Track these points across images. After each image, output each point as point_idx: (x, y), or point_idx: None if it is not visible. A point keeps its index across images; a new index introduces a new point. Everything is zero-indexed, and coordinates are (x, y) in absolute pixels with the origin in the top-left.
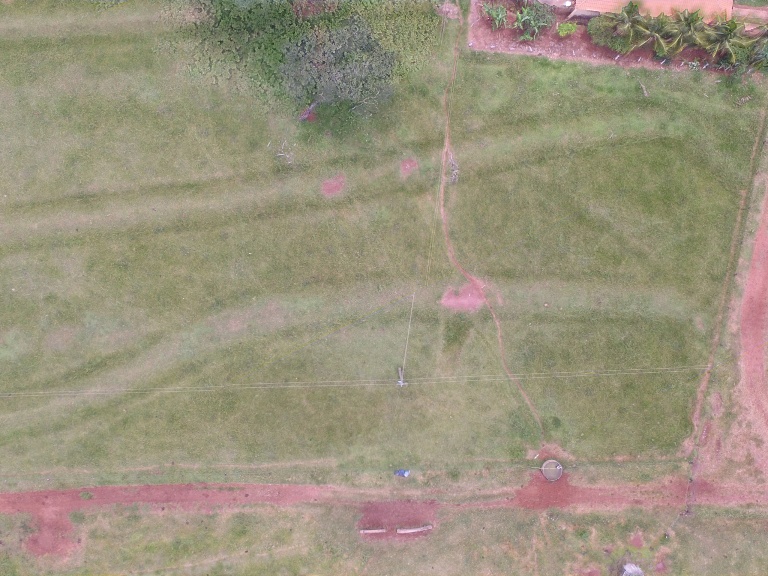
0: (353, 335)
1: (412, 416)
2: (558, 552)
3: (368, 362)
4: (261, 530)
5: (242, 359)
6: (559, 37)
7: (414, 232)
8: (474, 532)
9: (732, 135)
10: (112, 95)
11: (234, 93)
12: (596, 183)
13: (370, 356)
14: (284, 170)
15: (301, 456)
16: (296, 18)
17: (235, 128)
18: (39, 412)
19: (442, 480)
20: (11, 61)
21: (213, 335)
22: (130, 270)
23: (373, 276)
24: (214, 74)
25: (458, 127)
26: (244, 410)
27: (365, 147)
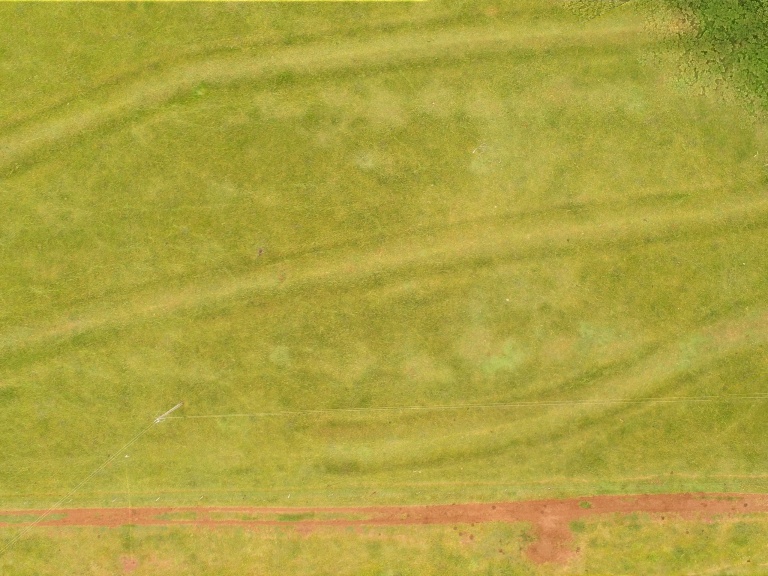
0: None
1: None
2: None
3: None
4: (761, 540)
5: (739, 369)
6: None
7: None
8: None
9: None
10: (601, 106)
11: (721, 103)
12: None
13: None
14: None
15: None
16: None
17: (723, 138)
18: (538, 422)
19: None
20: (498, 72)
21: (711, 345)
22: (623, 280)
23: None
24: (701, 85)
25: None
26: (740, 420)
27: None
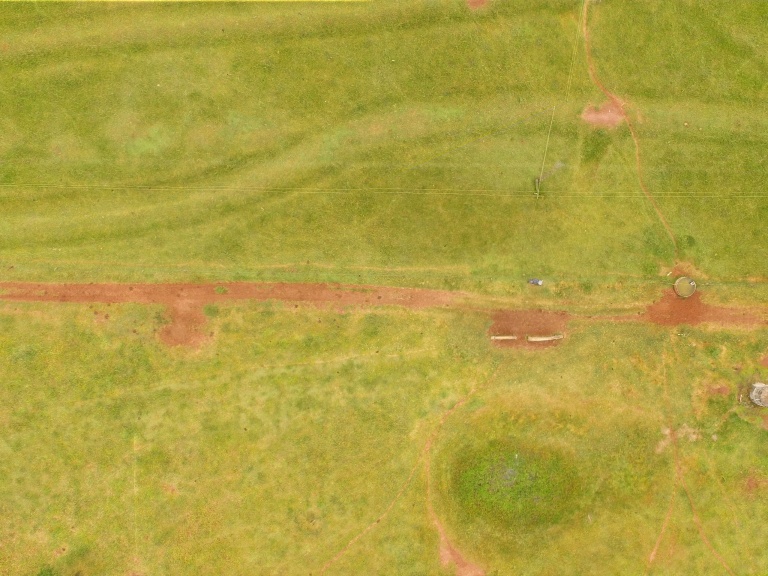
0: (492, 145)
1: (547, 228)
2: (687, 368)
3: (505, 173)
4: (392, 332)
5: (381, 163)
6: None
7: (556, 48)
8: (604, 344)
9: None
10: None
11: None
12: (740, 8)
13: (508, 167)
14: None
15: (435, 261)
16: None
17: None
18: (179, 205)
19: (574, 291)
20: None
21: (354, 138)
22: (274, 72)
23: (513, 89)
24: None
25: None
26: (380, 214)
27: None
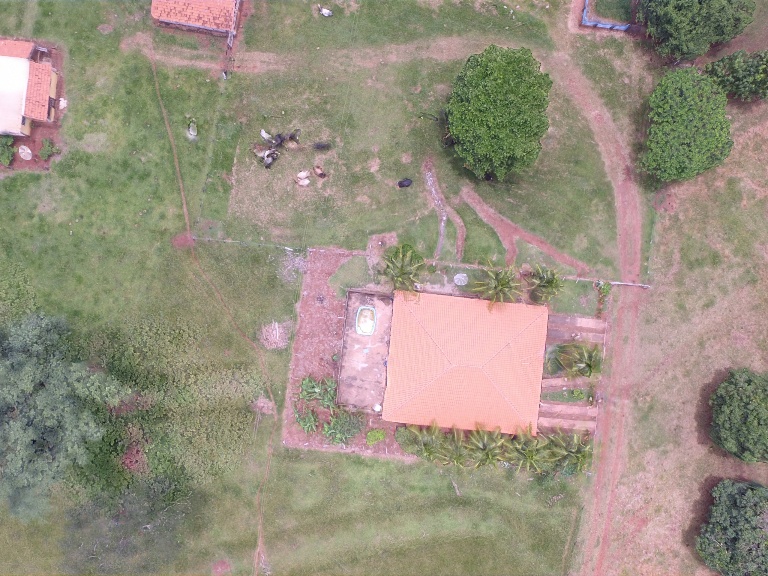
0: None
1: None
2: None
3: None
4: None
5: None
6: None
7: None
8: None
9: (544, 535)
10: None
11: (46, 494)
12: None
13: None
14: (95, 573)
15: None
16: (110, 416)
17: (47, 530)
18: None
19: None
20: None
21: None
22: None
23: None
24: (26, 476)
25: (270, 527)
26: None
27: (177, 548)
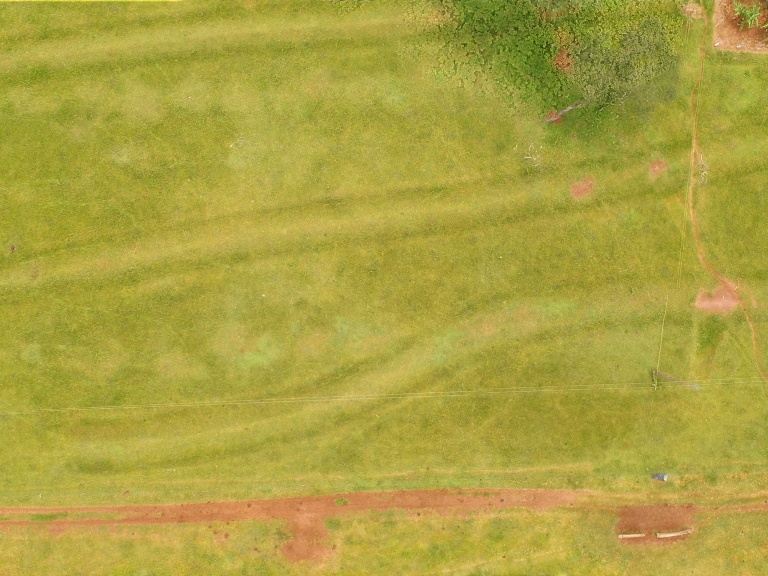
0: (607, 338)
1: (667, 419)
2: None
3: (621, 365)
4: (518, 535)
5: (495, 363)
6: None
7: (664, 234)
8: (733, 536)
9: None
10: (358, 99)
11: (480, 96)
12: None
13: (624, 359)
14: (532, 173)
15: (557, 460)
16: (539, 20)
17: (481, 131)
18: (293, 418)
19: (700, 484)
20: (255, 66)
21: (467, 339)
22: (380, 275)
23: (624, 279)
24: (460, 77)
25: (706, 128)
26: (497, 415)
27: (612, 149)
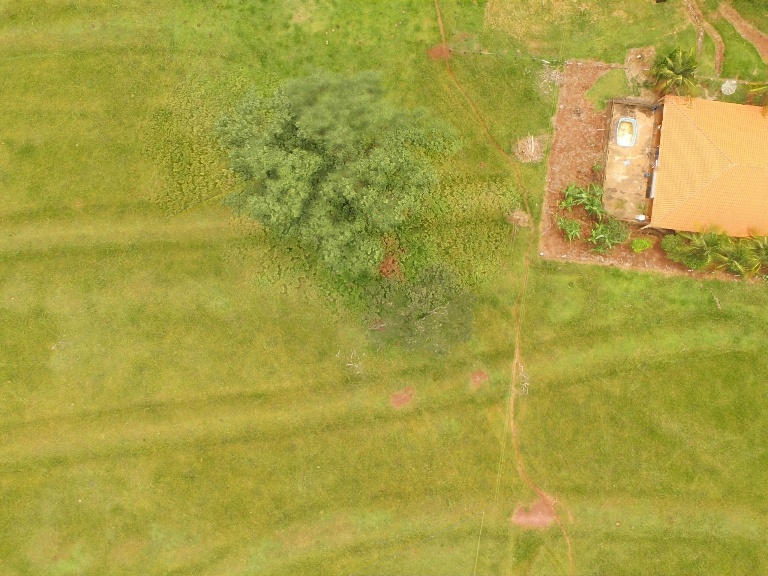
0: (422, 552)
1: None
2: None
3: None
4: None
5: (310, 575)
6: (632, 249)
7: (484, 446)
8: None
9: None
10: (181, 304)
11: (303, 302)
12: (668, 397)
13: (439, 573)
14: (353, 381)
15: None
16: (366, 225)
17: (304, 337)
18: None
19: None
20: (80, 267)
21: (281, 551)
22: (197, 482)
23: (442, 490)
24: (283, 283)
25: (529, 338)
26: None
27: (435, 358)
